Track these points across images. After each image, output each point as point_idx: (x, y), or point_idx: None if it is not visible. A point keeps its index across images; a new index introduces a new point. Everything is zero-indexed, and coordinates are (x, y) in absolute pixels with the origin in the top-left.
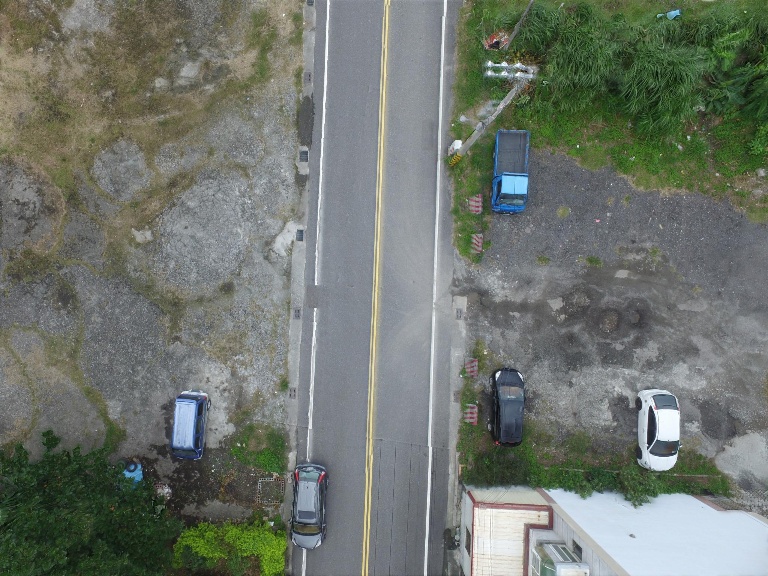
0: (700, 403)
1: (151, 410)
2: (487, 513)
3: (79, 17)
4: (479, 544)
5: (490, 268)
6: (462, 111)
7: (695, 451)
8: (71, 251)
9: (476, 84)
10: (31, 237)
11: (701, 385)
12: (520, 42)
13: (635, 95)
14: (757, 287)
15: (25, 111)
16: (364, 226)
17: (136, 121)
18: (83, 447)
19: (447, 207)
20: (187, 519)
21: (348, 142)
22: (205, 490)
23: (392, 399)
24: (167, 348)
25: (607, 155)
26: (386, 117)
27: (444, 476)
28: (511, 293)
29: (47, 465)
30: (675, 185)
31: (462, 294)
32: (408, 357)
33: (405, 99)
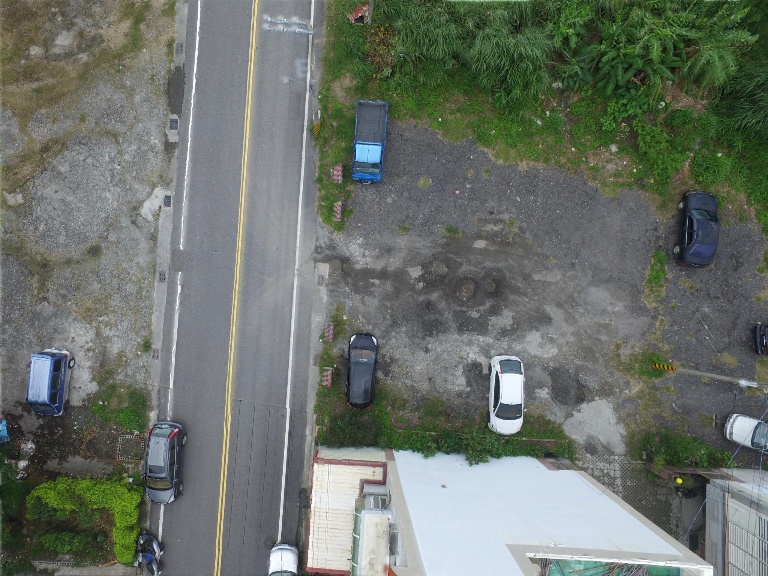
0: (551, 370)
1: (16, 368)
2: (325, 468)
3: None
4: (316, 498)
5: (352, 236)
6: (328, 83)
7: (544, 416)
8: None
9: (342, 57)
10: None
11: (552, 353)
12: (380, 16)
13: (484, 68)
14: (609, 259)
15: None
16: (230, 193)
17: (10, 87)
18: None
19: (312, 176)
20: (49, 474)
21: (217, 111)
22: (67, 446)
23: (252, 361)
24: (34, 308)
25: (468, 129)
26: (253, 88)
27: (301, 437)
28: (371, 261)
29: None
30: (533, 159)
31: (324, 261)
32: (269, 321)
33: (273, 71)
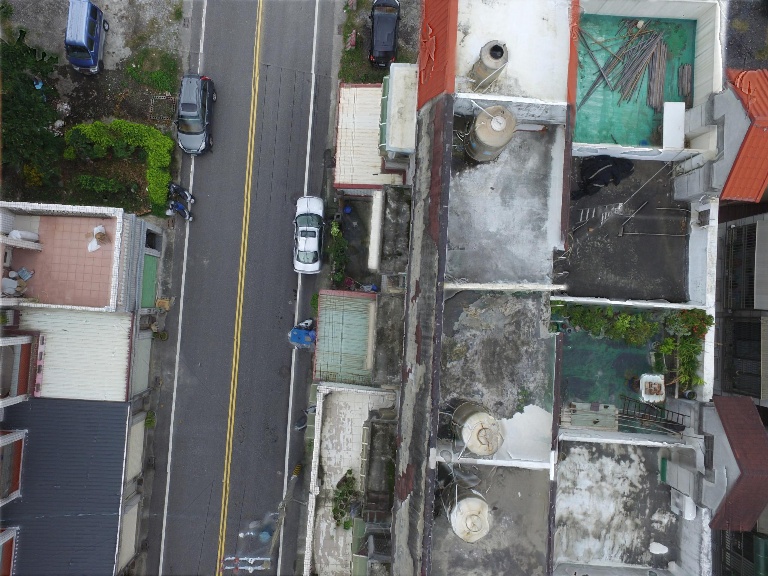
0: None
1: (53, 33)
2: (351, 92)
3: None
4: (343, 120)
5: None
6: None
7: None
8: None
9: None
10: None
11: None
12: None
13: None
14: None
15: None
16: None
17: None
18: None
19: None
20: None
21: None
22: (102, 107)
23: (279, 29)
24: None
25: None
26: None
27: (326, 101)
28: None
29: None
30: None
31: None
32: None
33: None
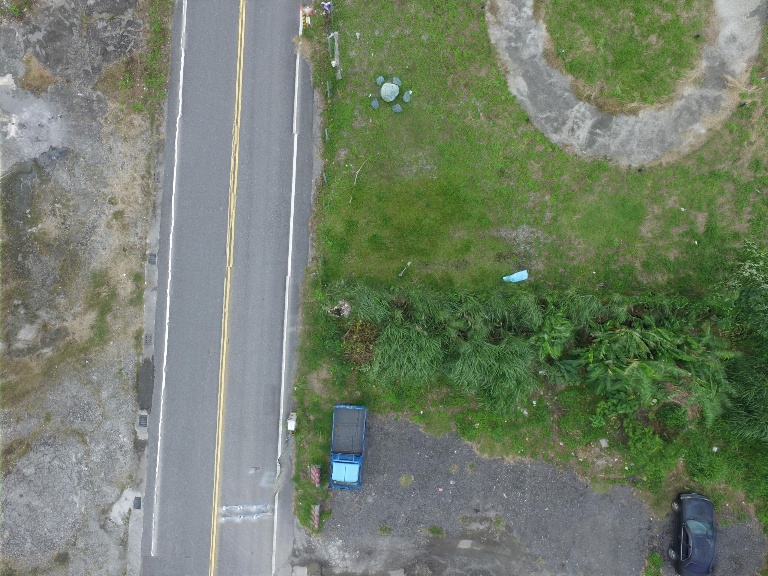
0: None
1: None
2: None
3: None
4: None
5: (331, 537)
6: (304, 376)
7: None
8: None
9: (318, 349)
10: None
11: None
12: None
13: None
14: (601, 559)
15: None
16: (202, 495)
17: None
18: None
19: (288, 474)
20: None
21: (188, 407)
22: None
23: None
24: None
25: (451, 422)
26: (226, 383)
27: None
28: (352, 564)
29: None
30: (519, 454)
31: (302, 564)
32: None
33: (247, 362)
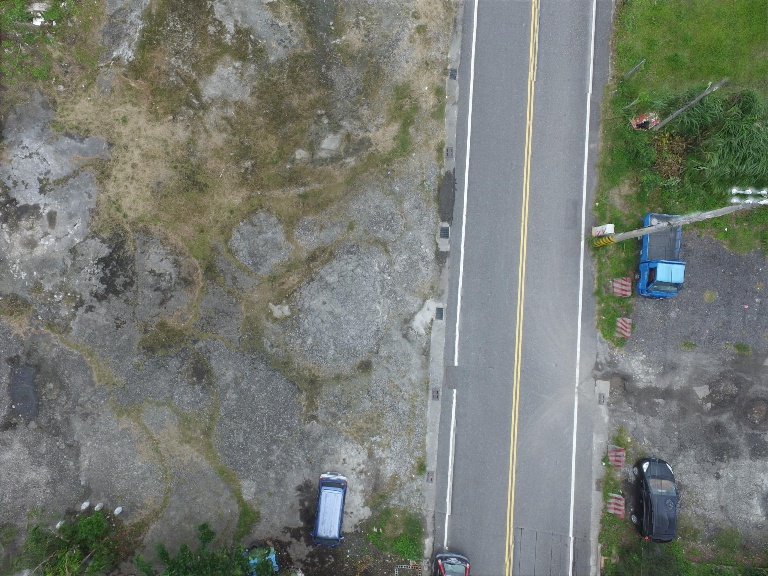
0: None
1: (285, 491)
2: None
3: (220, 86)
4: None
5: (634, 352)
6: (608, 190)
7: None
8: (207, 325)
9: (623, 164)
10: (167, 309)
11: None
12: (675, 125)
13: None
14: None
15: (163, 180)
16: (506, 306)
17: (275, 193)
18: (215, 528)
19: (591, 288)
20: None
21: (490, 219)
22: (339, 575)
23: (533, 486)
24: (303, 427)
25: (756, 239)
26: (530, 195)
27: (585, 568)
28: (656, 379)
29: (208, 564)
30: None
31: (605, 378)
32: (550, 443)
33: (549, 177)
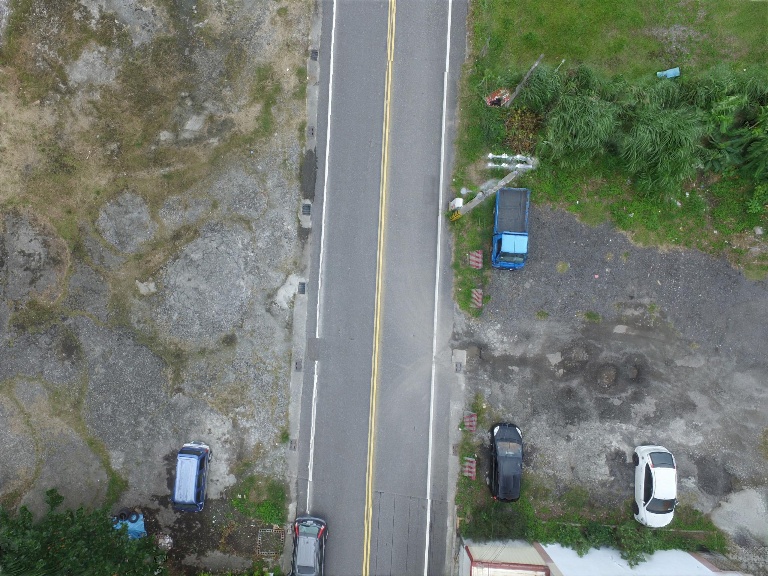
0: (697, 459)
1: (153, 461)
2: (484, 572)
3: (86, 70)
4: None
5: (490, 322)
6: (463, 166)
7: (691, 507)
8: (76, 302)
9: (477, 140)
10: (36, 288)
11: (698, 441)
12: (521, 101)
13: (634, 157)
14: (754, 344)
15: (31, 163)
16: (365, 280)
17: (141, 174)
18: (86, 497)
19: (448, 261)
20: (188, 569)
21: (350, 196)
22: (206, 541)
23: (391, 452)
24: (169, 399)
25: (606, 211)
26: (388, 172)
27: (442, 529)
28: (510, 347)
29: (51, 526)
30: (673, 242)
31: (462, 348)
32: (408, 410)
33: (407, 154)
